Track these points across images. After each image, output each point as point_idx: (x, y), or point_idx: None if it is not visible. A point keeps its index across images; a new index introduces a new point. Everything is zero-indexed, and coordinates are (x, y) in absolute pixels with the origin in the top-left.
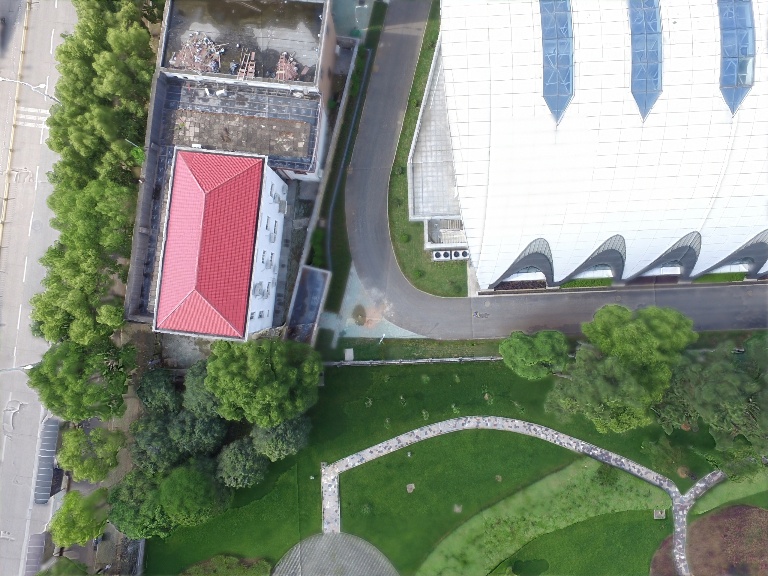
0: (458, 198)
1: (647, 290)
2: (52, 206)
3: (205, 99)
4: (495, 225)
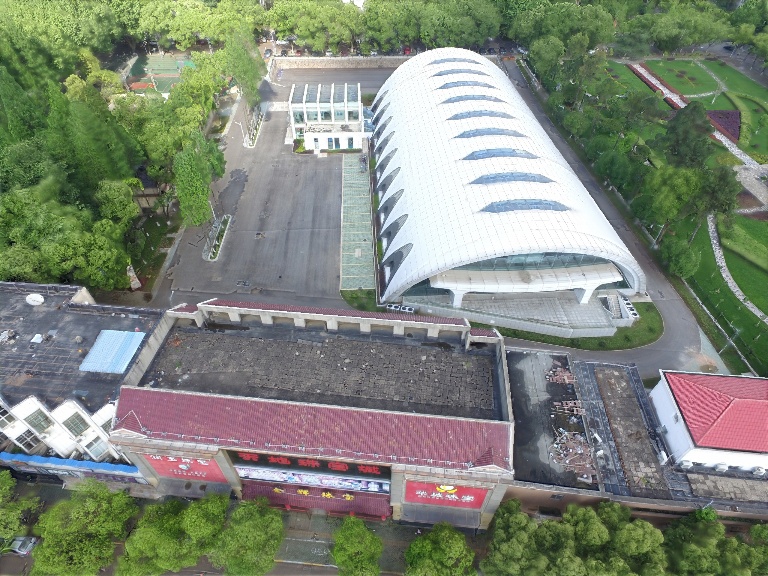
0: None
1: None
2: None
3: (606, 458)
4: None
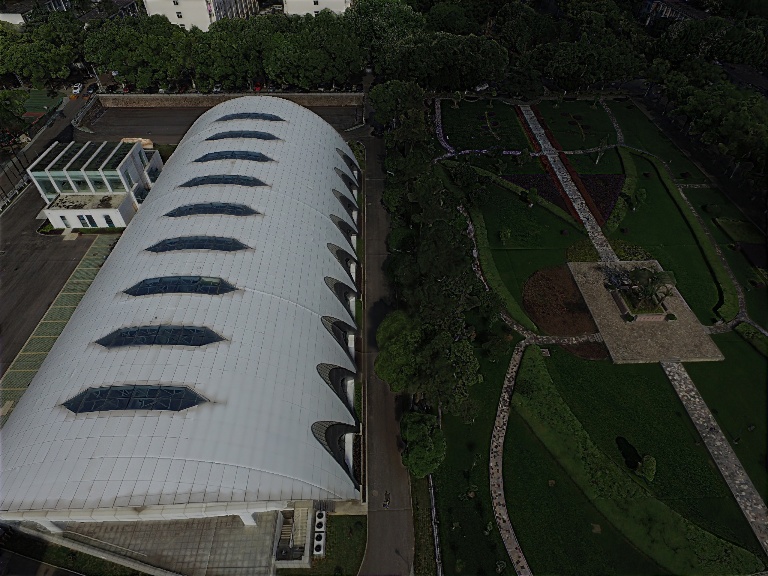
0: None
1: (366, 358)
2: None
3: None
4: (292, 467)
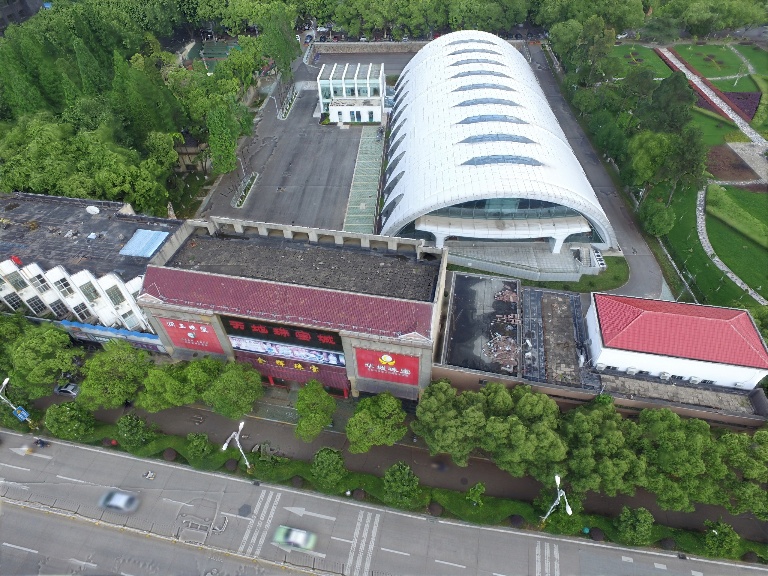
0: (591, 210)
1: None
2: (686, 494)
3: (533, 359)
4: None
